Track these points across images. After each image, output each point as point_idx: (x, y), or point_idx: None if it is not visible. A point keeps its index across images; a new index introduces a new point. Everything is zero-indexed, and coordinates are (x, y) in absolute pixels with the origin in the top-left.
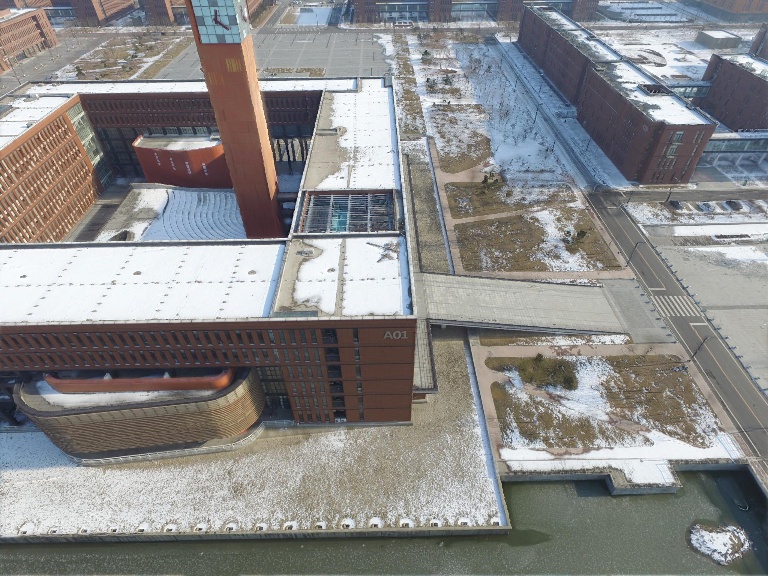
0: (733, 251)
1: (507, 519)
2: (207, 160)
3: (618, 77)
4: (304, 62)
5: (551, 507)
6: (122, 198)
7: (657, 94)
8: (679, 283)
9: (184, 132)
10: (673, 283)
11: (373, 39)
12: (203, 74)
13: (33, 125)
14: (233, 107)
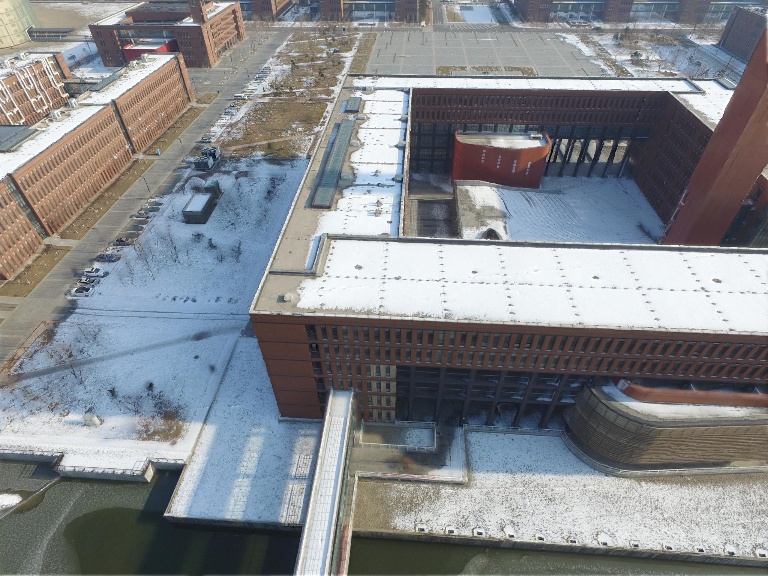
0: None
1: None
2: (534, 159)
3: None
4: (506, 61)
5: None
6: (432, 194)
7: None
8: None
9: (499, 130)
10: None
11: (559, 39)
12: (413, 70)
13: (409, 118)
14: None
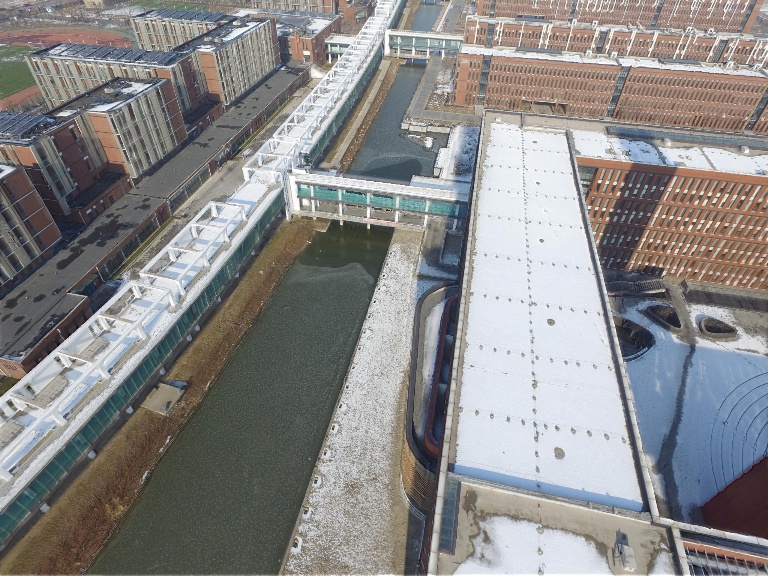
0: None
1: None
2: None
3: None
4: None
5: None
6: None
7: None
8: None
9: None
10: None
11: None
12: None
13: None
14: None
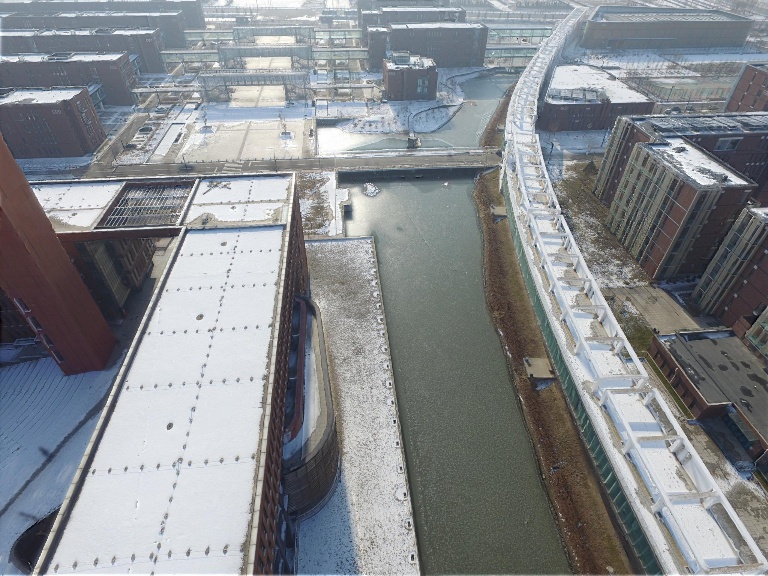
0: (192, 141)
1: (369, 237)
2: None
3: None
4: None
5: (358, 229)
6: None
7: (8, 94)
8: (213, 162)
9: None
10: (213, 164)
11: None
12: None
13: None
14: (4, 175)
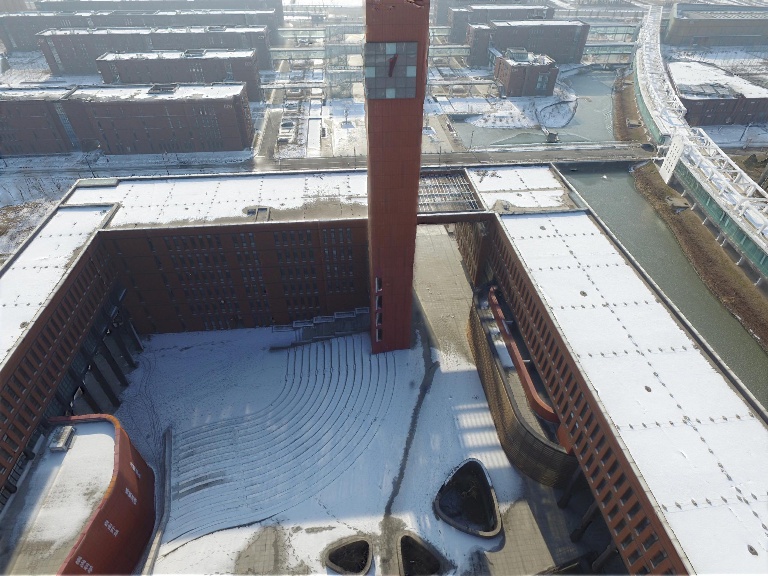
0: (339, 135)
1: None
2: None
3: (115, 97)
4: None
5: None
6: None
7: (176, 89)
8: None
9: None
10: None
11: None
12: None
13: None
14: None
